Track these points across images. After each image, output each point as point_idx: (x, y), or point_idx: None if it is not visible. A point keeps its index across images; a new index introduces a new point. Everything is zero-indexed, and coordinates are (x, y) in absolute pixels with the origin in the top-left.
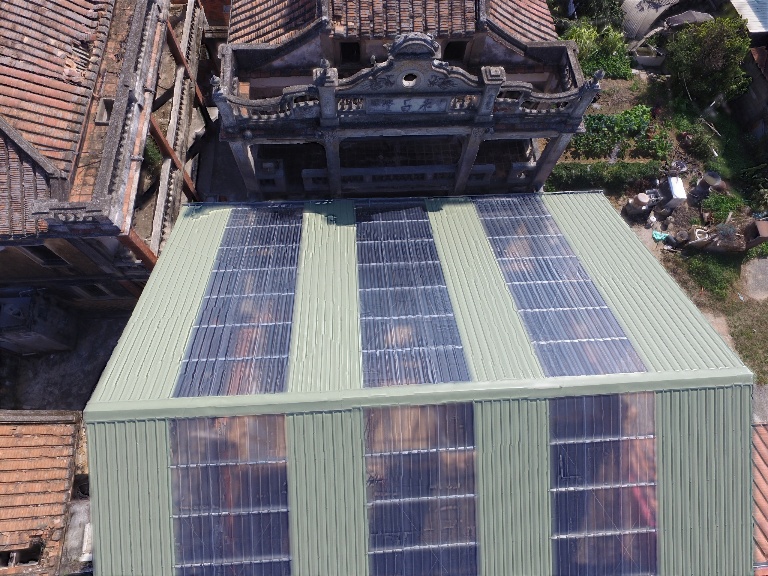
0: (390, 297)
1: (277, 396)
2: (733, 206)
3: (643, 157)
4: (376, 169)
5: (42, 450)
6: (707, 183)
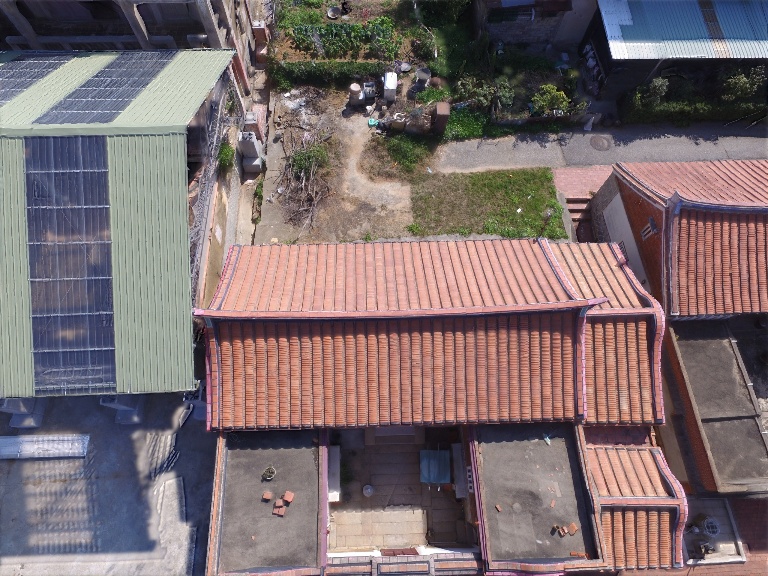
0: None
1: None
2: (439, 97)
3: (375, 59)
4: (69, 37)
5: None
6: (418, 77)
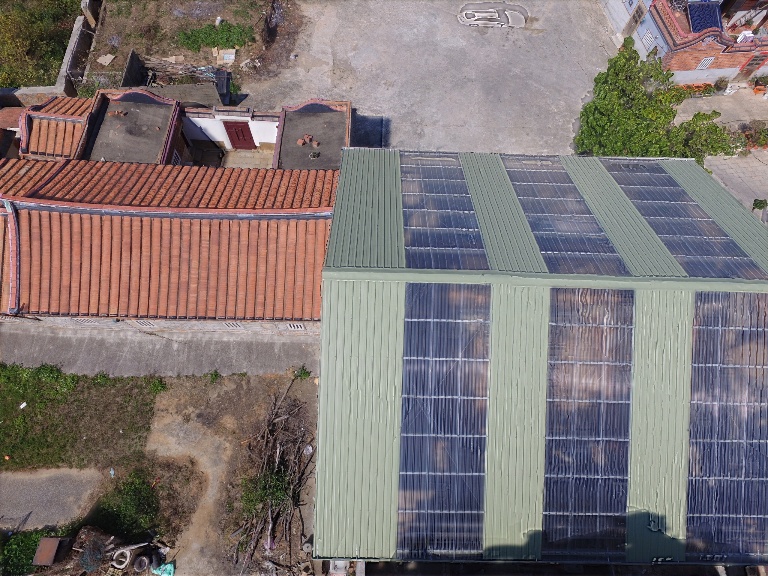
0: (602, 390)
1: (700, 287)
2: None
3: None
4: None
5: None
6: None
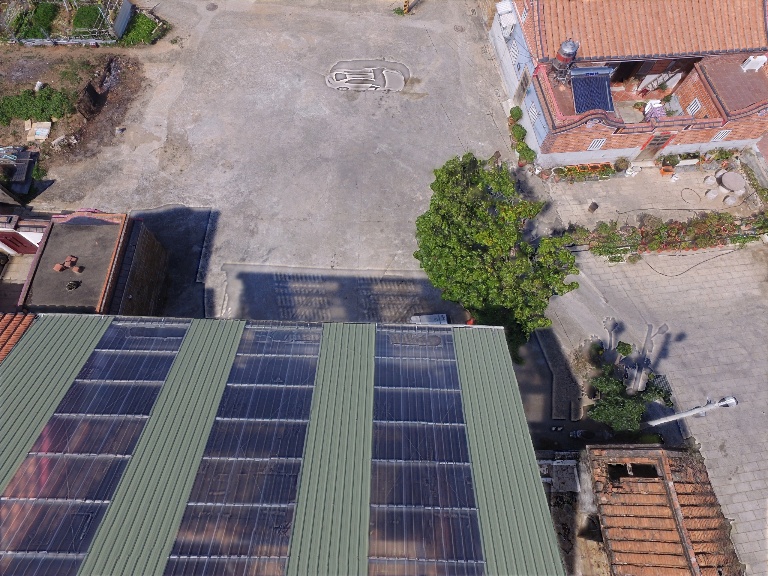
0: None
1: None
2: None
3: None
4: None
5: (644, 574)
6: None
